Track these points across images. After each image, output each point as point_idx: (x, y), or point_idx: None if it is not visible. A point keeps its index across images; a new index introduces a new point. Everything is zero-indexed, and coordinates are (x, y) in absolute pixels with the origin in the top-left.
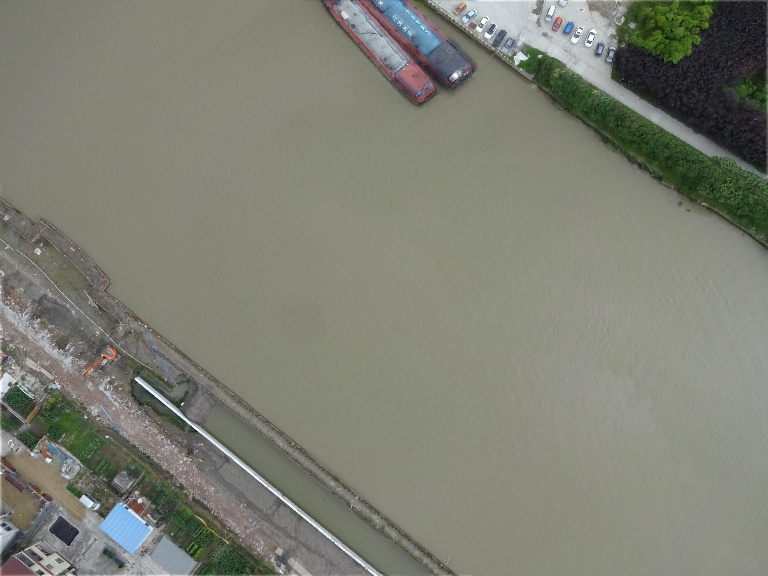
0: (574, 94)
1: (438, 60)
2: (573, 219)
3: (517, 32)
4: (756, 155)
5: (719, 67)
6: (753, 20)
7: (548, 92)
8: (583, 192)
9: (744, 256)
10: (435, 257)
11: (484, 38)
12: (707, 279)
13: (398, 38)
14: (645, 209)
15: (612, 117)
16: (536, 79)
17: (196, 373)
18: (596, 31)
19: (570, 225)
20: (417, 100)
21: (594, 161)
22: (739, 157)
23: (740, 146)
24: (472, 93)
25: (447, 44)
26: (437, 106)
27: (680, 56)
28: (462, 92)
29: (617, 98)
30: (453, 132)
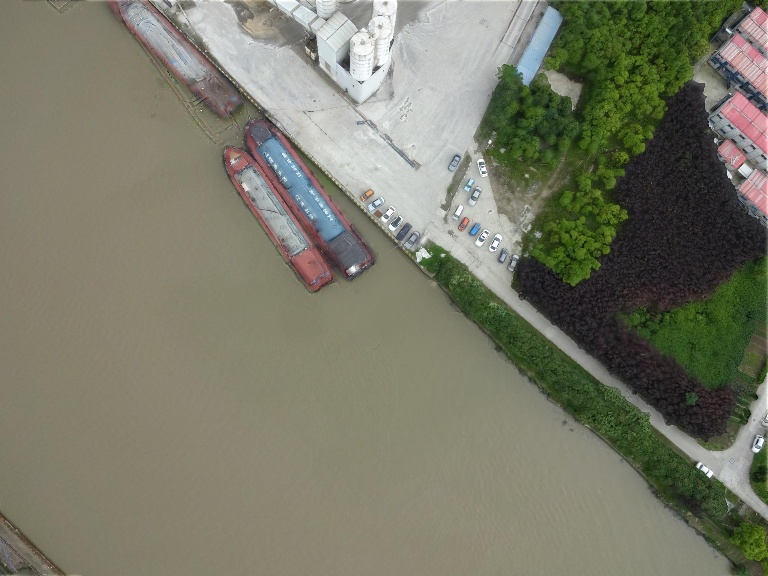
0: (471, 304)
1: (337, 250)
2: (457, 429)
3: (423, 226)
4: (640, 390)
5: (615, 295)
6: (653, 249)
7: (447, 292)
8: (470, 402)
9: (620, 482)
10: (311, 456)
11: (388, 229)
12: (581, 504)
13: (300, 218)
14: (529, 425)
15: (505, 334)
16: (436, 278)
17: (39, 562)
18: (502, 236)
19: (453, 435)
20: (311, 287)
21: (486, 368)
22: (625, 384)
23: (626, 378)
24: (370, 284)
25: (348, 233)
26: (333, 293)
27: (578, 280)
28: (360, 282)
29: (515, 308)
30: (345, 324)
